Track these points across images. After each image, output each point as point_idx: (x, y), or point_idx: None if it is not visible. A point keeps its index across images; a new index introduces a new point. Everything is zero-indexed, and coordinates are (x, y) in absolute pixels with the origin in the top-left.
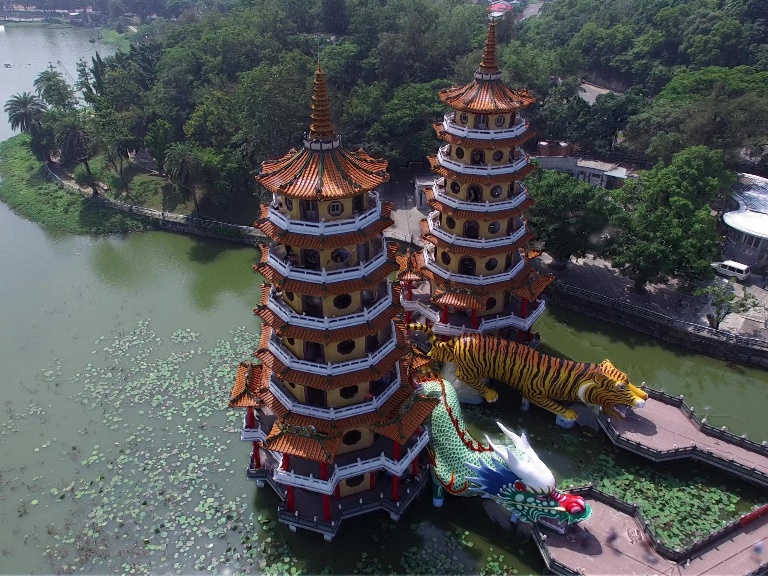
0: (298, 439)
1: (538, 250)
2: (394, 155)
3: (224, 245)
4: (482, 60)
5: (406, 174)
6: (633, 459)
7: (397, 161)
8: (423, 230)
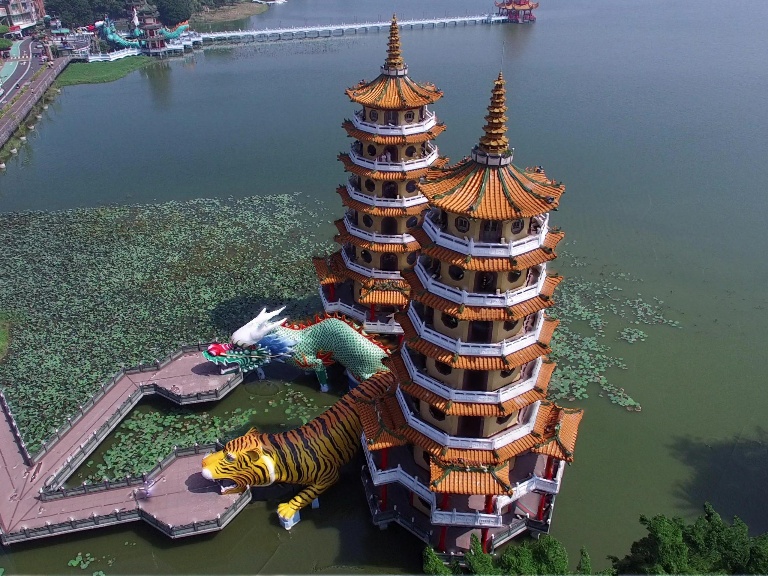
0: None
1: (436, 480)
2: None
3: None
4: None
5: None
6: None
7: None
8: None
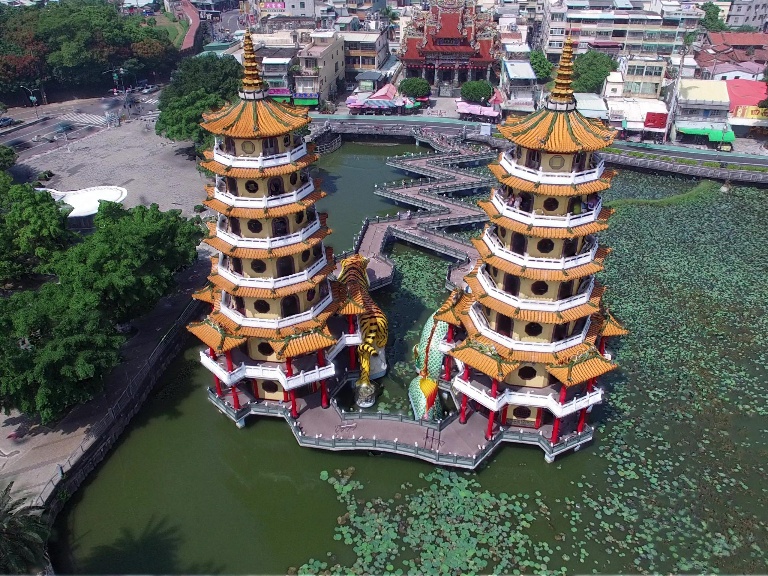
0: None
1: None
2: None
3: None
4: None
5: None
6: None
7: None
8: (298, 289)
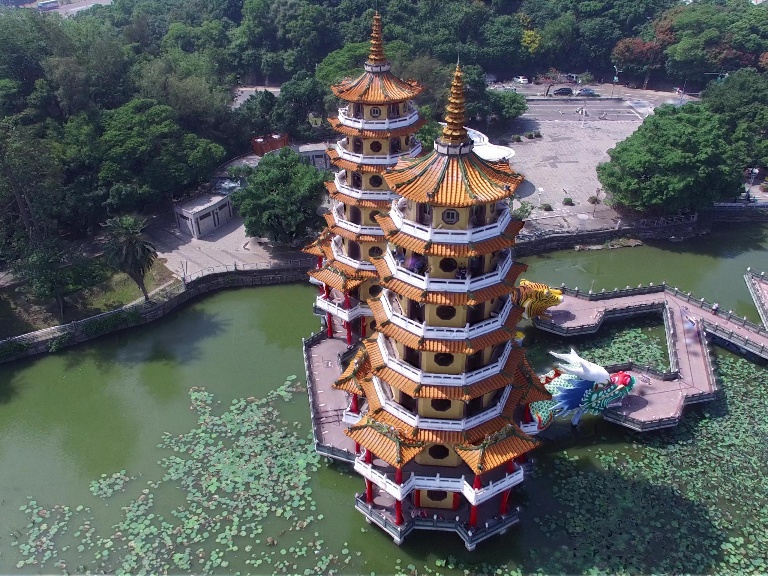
0: (498, 446)
1: None
2: (148, 191)
3: (2, 371)
4: (161, 71)
5: (142, 211)
6: (579, 340)
7: (152, 196)
8: (346, 235)
